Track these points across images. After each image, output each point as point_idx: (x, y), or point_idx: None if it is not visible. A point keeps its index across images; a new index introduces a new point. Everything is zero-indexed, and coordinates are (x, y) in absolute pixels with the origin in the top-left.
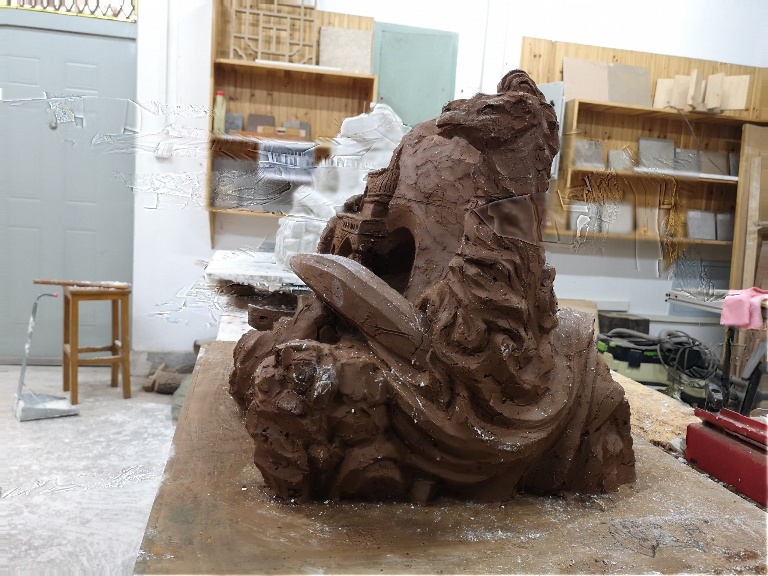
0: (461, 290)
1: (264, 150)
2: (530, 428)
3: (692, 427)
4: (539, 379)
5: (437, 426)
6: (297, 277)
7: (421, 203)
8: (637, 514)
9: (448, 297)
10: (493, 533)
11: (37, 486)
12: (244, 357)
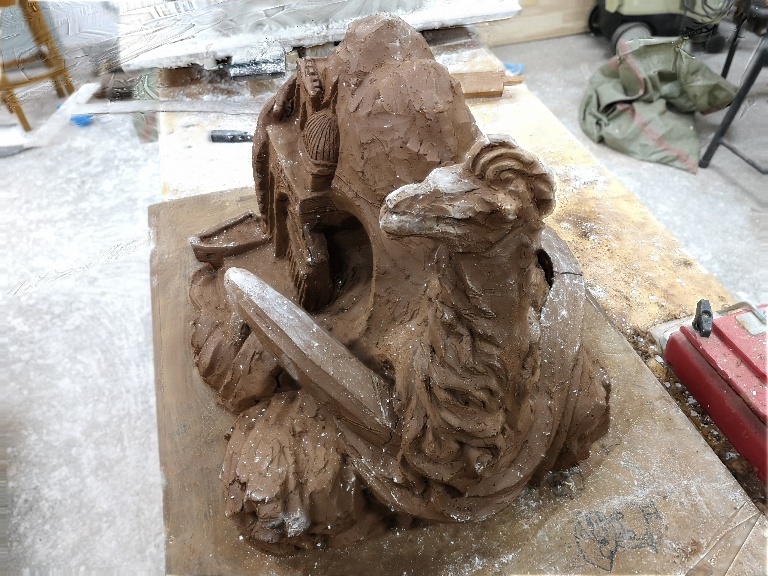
0: (429, 407)
1: (142, 6)
2: (506, 492)
3: (674, 339)
4: (516, 450)
5: (414, 515)
6: (234, 48)
7: (373, 206)
8: (603, 497)
9: (415, 400)
10: (471, 563)
11: (39, 279)
12: (204, 373)
